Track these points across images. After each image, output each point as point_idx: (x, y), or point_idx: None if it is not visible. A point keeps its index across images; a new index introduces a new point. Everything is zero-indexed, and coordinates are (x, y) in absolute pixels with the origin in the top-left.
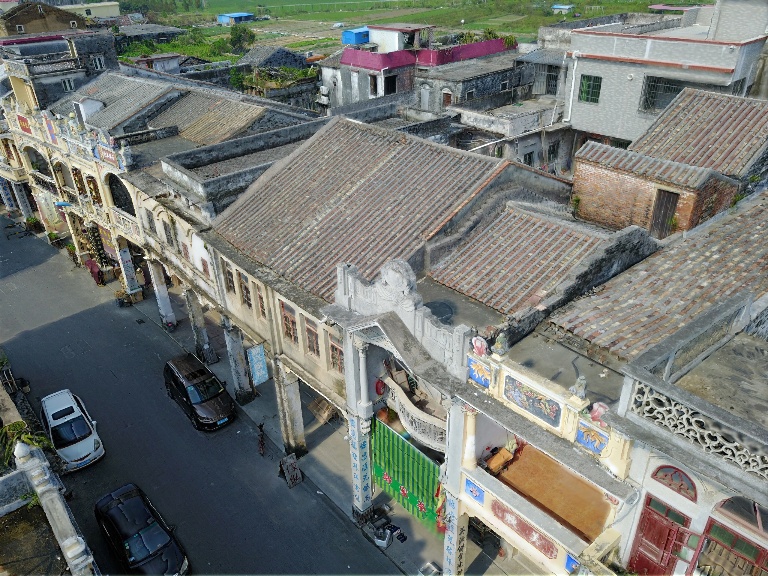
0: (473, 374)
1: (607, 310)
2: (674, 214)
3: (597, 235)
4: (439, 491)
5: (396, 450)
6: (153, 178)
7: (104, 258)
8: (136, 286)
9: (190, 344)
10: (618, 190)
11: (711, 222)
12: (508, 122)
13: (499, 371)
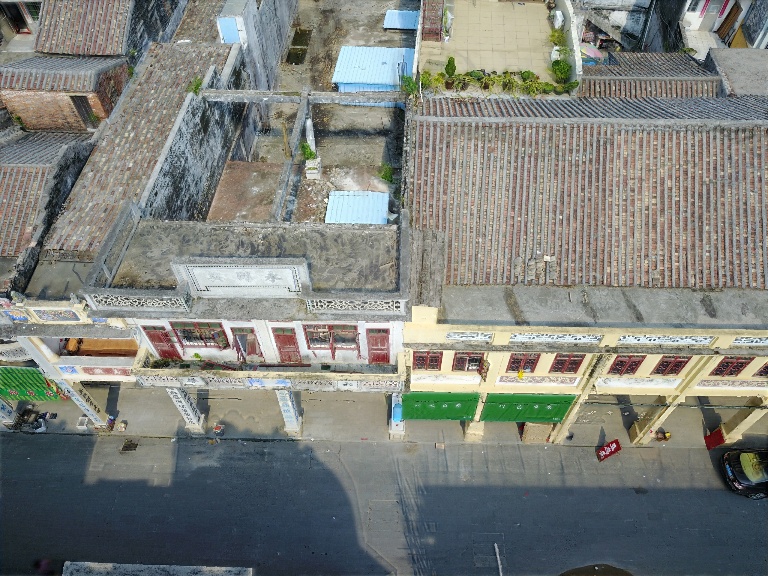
0: (14, 317)
1: (78, 220)
2: (92, 110)
3: (43, 166)
4: (48, 383)
5: (4, 375)
6: None
7: None
8: None
9: None
10: (43, 103)
11: (122, 98)
12: None
13: (27, 310)
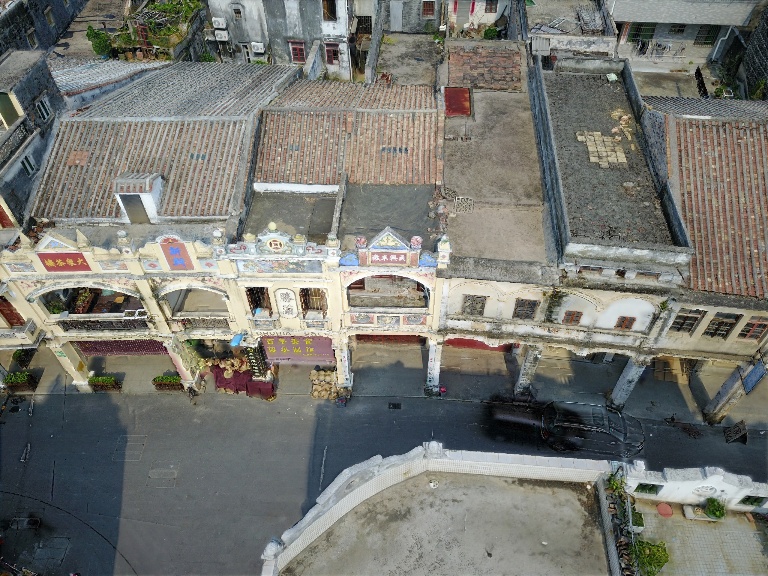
0: None
1: None
2: None
3: None
4: None
5: None
6: (498, 261)
7: (264, 368)
8: (350, 375)
9: (483, 394)
10: None
11: None
12: (615, 40)
13: None
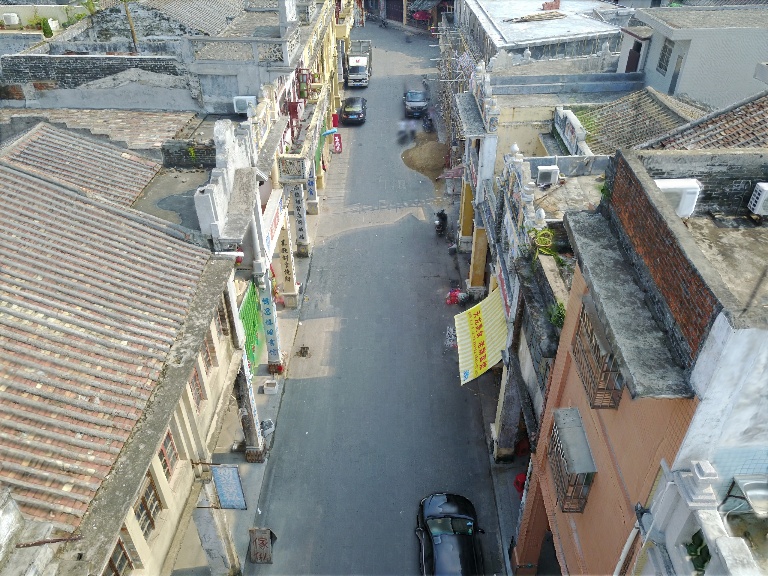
0: None
1: None
2: None
3: (37, 127)
4: None
5: None
6: None
7: None
8: None
9: None
10: None
11: None
12: None
13: None
